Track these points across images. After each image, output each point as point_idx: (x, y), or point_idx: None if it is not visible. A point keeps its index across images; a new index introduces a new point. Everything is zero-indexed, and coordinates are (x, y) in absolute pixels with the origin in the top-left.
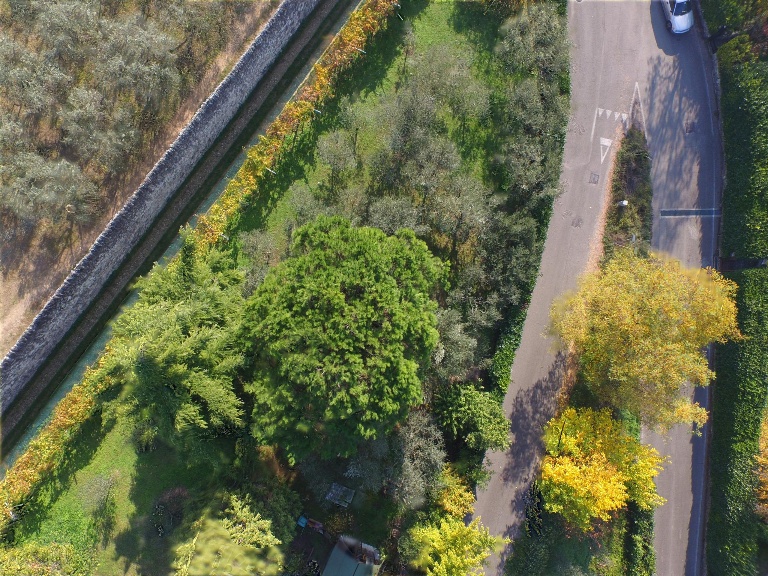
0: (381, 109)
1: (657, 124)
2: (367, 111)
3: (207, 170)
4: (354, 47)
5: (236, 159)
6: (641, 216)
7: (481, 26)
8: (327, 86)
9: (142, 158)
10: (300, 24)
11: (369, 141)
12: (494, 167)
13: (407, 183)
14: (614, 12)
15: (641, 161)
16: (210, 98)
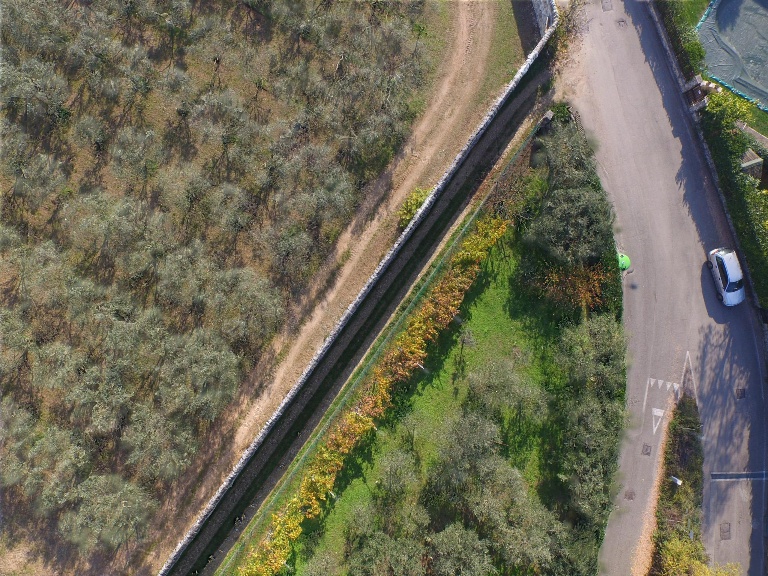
0: (438, 402)
1: (708, 391)
2: (424, 405)
3: (263, 458)
4: (416, 362)
5: (292, 446)
6: (693, 487)
7: (536, 311)
8: (389, 403)
9: (198, 446)
10: (356, 309)
11: (426, 436)
12: (550, 455)
13: (464, 478)
14: (665, 282)
15: (693, 433)
16: (273, 419)
